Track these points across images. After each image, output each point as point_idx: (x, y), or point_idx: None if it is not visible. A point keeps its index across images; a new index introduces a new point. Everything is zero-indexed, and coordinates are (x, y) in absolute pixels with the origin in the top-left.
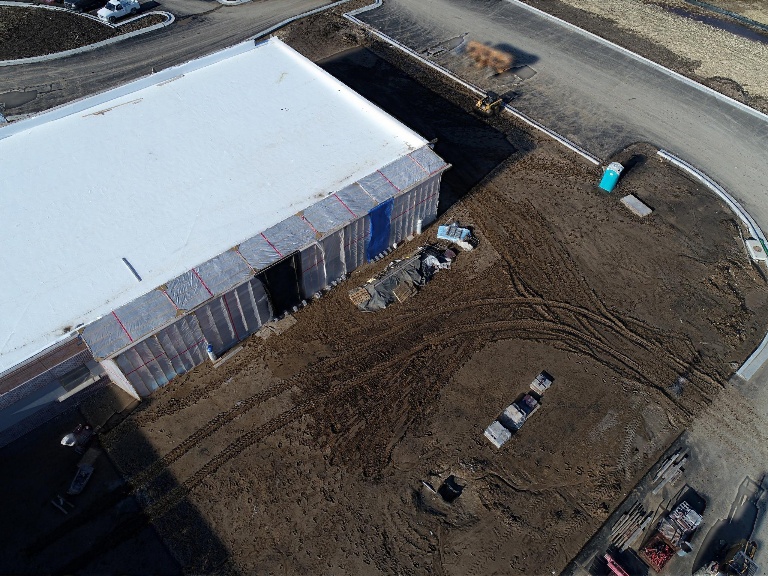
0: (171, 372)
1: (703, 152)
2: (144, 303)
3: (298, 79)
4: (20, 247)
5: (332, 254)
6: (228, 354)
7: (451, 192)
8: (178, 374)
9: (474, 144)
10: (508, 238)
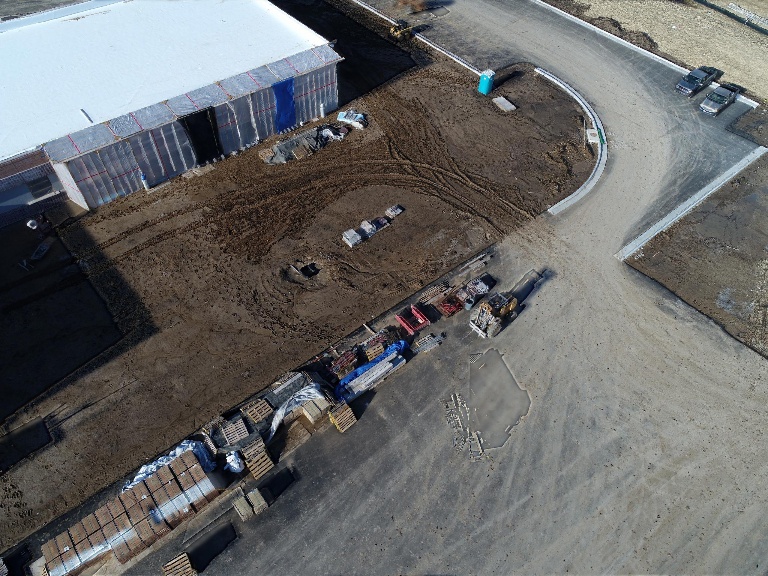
0: (113, 191)
1: (572, 70)
2: (91, 131)
3: (237, 1)
4: (5, 100)
5: (244, 118)
6: (159, 186)
7: (355, 91)
8: (119, 195)
9: (382, 59)
10: (393, 122)
